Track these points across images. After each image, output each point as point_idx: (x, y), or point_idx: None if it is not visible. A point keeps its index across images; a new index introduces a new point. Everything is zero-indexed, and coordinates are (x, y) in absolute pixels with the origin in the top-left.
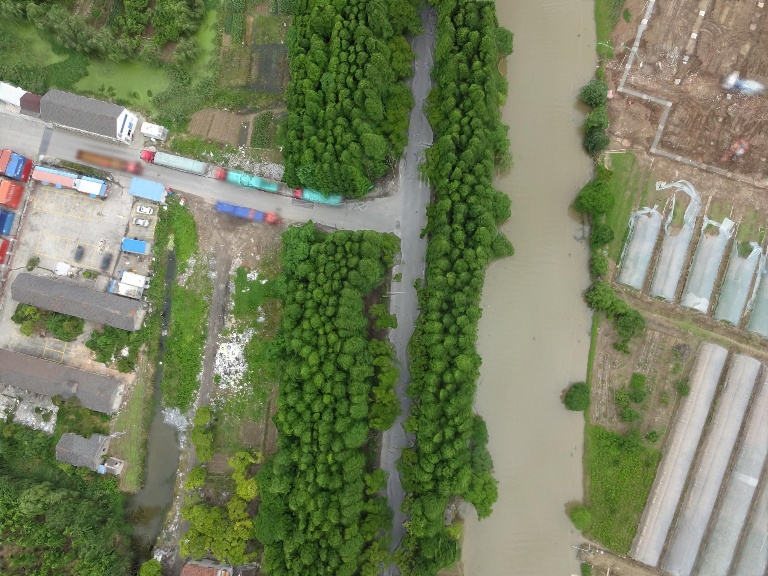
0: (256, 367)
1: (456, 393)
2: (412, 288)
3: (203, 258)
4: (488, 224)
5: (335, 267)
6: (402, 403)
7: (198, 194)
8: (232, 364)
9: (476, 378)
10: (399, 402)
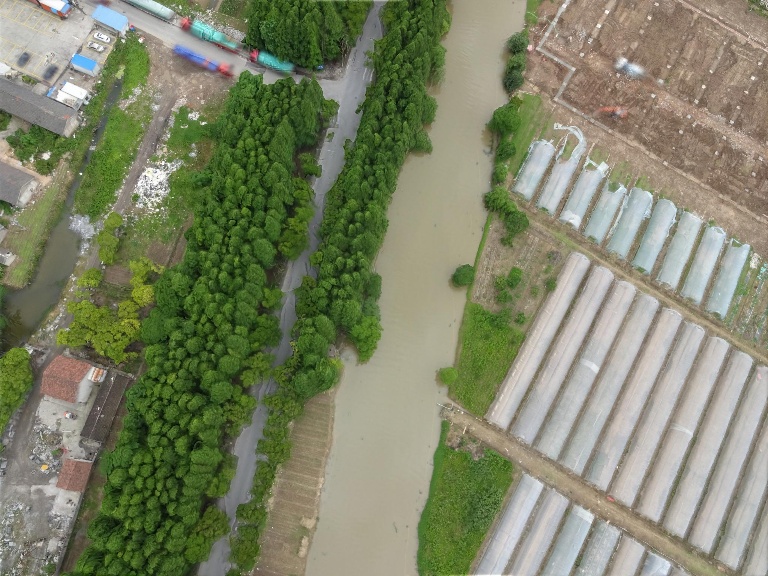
0: (177, 194)
1: (363, 233)
2: (339, 157)
3: (149, 91)
4: (417, 103)
5: (278, 104)
6: (311, 241)
7: (159, 37)
8: (154, 187)
9: (381, 236)
10: (309, 238)
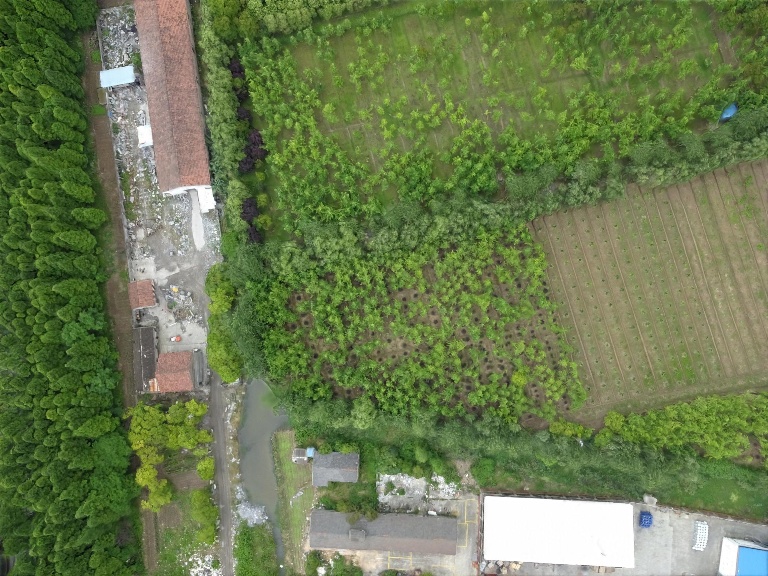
0: None
1: None
2: None
3: None
4: None
5: None
6: None
7: None
8: None
9: None
10: None
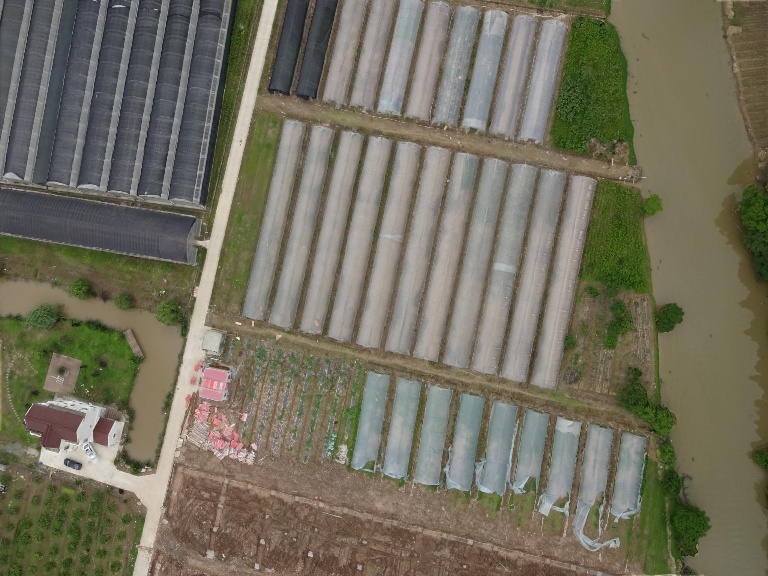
0: None
1: None
2: None
3: None
4: None
5: None
6: None
7: None
8: None
9: None
10: None
